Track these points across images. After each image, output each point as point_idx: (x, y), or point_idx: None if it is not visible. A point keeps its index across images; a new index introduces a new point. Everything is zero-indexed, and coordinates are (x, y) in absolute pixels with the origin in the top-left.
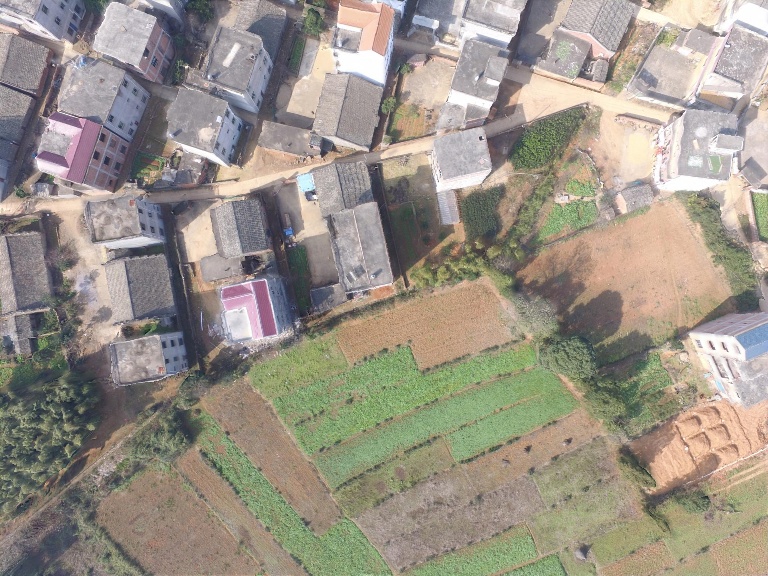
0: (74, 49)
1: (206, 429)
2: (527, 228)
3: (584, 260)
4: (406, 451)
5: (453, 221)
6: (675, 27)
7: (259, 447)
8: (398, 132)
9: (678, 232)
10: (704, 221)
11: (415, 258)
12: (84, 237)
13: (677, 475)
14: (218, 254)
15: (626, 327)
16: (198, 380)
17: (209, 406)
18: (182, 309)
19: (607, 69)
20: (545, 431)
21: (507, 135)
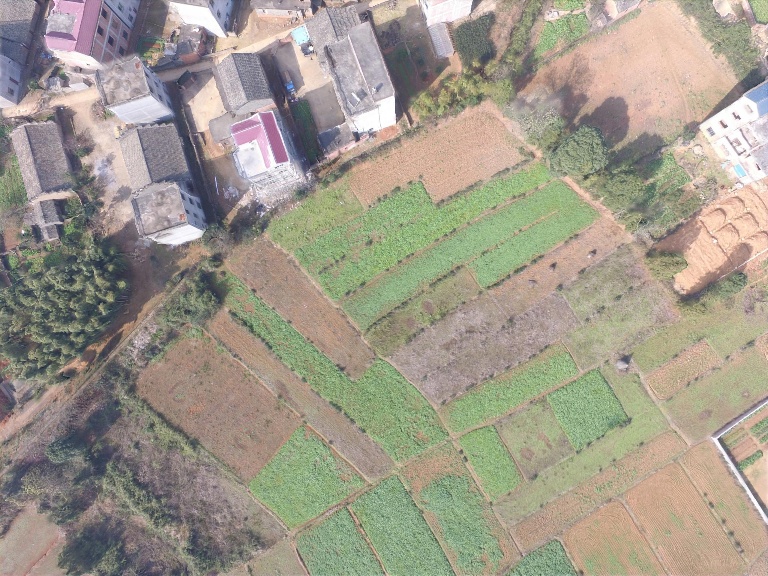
0: None
1: (233, 289)
2: (521, 45)
3: (582, 71)
4: (431, 284)
5: (447, 51)
6: None
7: (286, 300)
8: None
9: (673, 30)
10: (697, 12)
11: (415, 95)
12: (97, 124)
13: (709, 269)
14: (224, 108)
15: (634, 131)
16: (219, 229)
17: (233, 267)
18: (197, 177)
19: None
20: (568, 246)
21: None
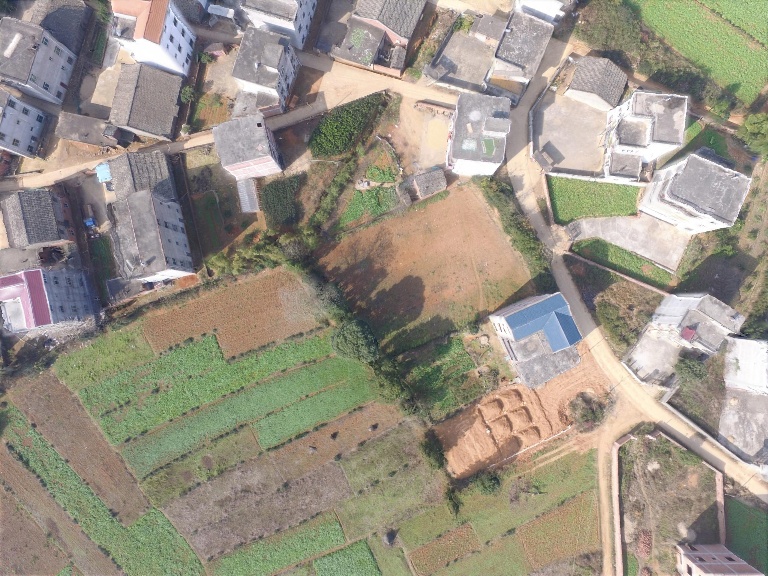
0: None
1: (12, 422)
2: (324, 215)
3: (385, 246)
4: (212, 440)
5: (252, 209)
6: (474, 14)
7: (66, 439)
8: (201, 121)
9: (477, 217)
10: (499, 205)
11: (218, 247)
12: None
13: (480, 458)
14: (9, 245)
15: (428, 312)
16: None
17: (15, 399)
18: None
19: (404, 56)
20: (351, 417)
21: (308, 123)
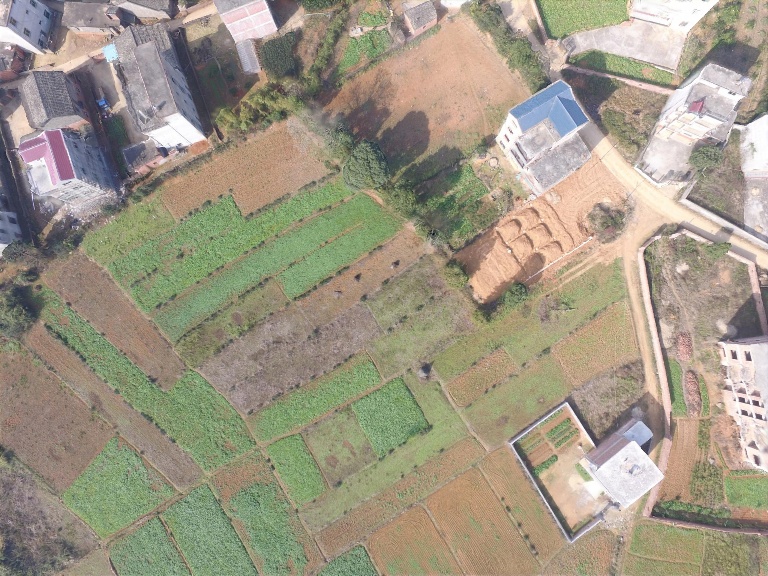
0: None
1: (48, 303)
2: (322, 61)
3: (385, 86)
4: (240, 296)
5: (253, 67)
6: None
7: (100, 313)
8: None
9: (471, 45)
10: (491, 28)
11: None
12: None
13: (504, 279)
14: (29, 125)
15: (435, 144)
16: (21, 244)
17: (49, 281)
18: (14, 192)
19: None
20: (372, 257)
21: None
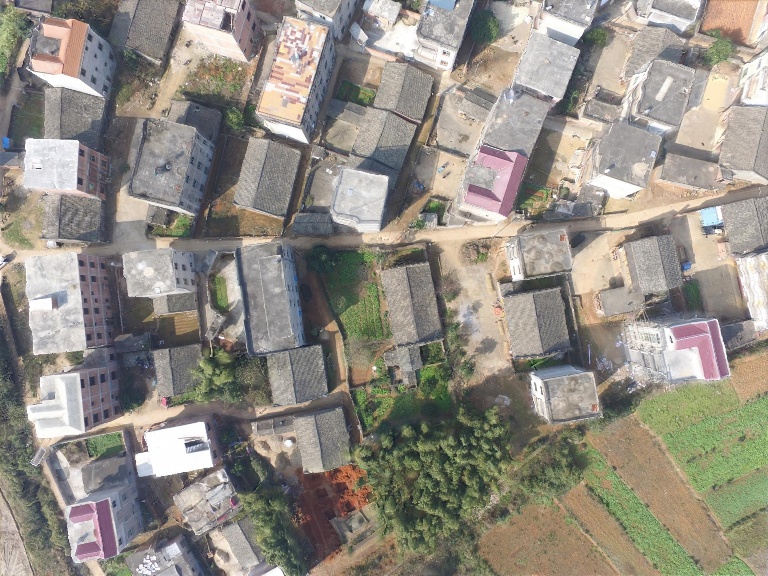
0: (451, 77)
1: (592, 463)
2: None
3: None
4: None
5: None
6: None
7: (646, 483)
8: None
9: None
10: None
11: None
12: (466, 267)
13: None
14: (634, 289)
15: None
16: (616, 417)
17: (595, 440)
18: None
19: None
20: None
21: None
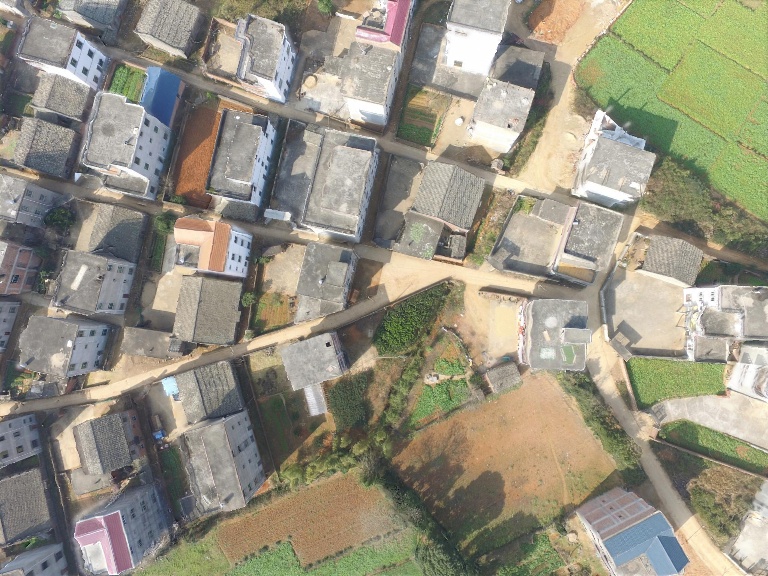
0: None
1: None
2: (395, 417)
3: (460, 441)
4: None
5: (321, 413)
6: (533, 192)
7: None
8: (263, 322)
9: (554, 405)
10: None
11: (288, 451)
12: None
13: None
14: (83, 472)
15: (510, 508)
16: None
17: None
18: (61, 519)
19: (465, 244)
20: None
21: (371, 317)
